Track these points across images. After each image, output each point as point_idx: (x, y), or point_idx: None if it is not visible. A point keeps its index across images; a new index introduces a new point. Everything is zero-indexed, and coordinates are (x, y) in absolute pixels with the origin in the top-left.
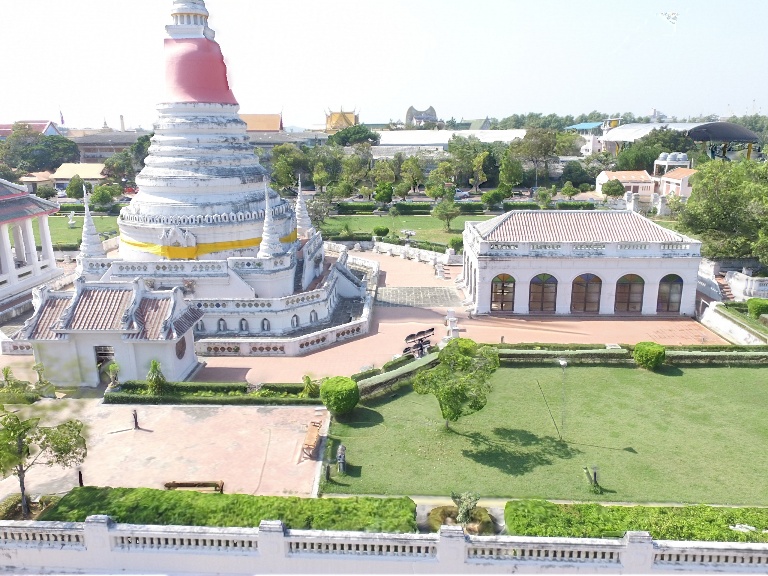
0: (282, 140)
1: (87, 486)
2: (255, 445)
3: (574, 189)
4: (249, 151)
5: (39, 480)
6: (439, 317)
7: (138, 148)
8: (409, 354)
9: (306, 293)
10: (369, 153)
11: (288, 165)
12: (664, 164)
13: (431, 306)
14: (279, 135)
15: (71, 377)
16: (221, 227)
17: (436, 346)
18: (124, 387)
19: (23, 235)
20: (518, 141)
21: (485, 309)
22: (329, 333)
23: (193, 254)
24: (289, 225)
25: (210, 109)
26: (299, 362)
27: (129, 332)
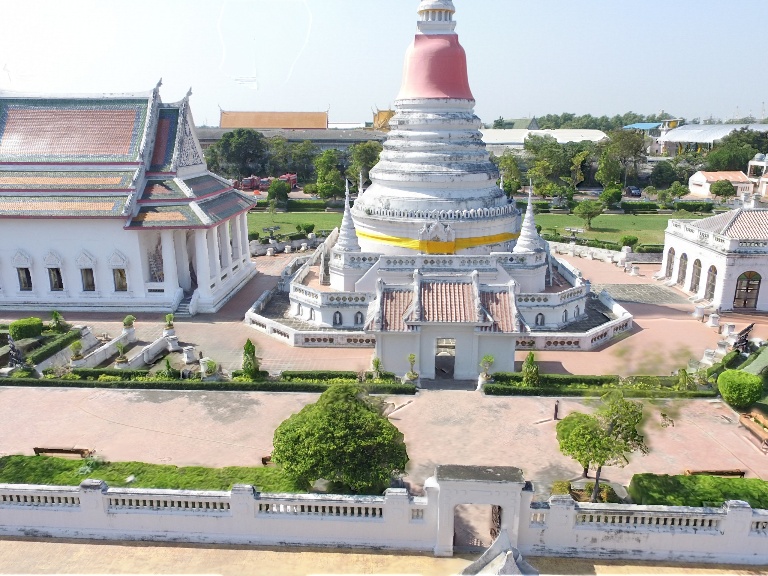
0: (363, 138)
1: (645, 473)
2: (697, 436)
3: (685, 189)
4: None
5: (531, 468)
6: (684, 313)
7: (225, 144)
8: (736, 349)
9: (574, 288)
10: None
11: None
12: (762, 165)
13: (662, 303)
14: (358, 133)
15: (408, 369)
16: (478, 222)
17: (751, 341)
18: (497, 379)
19: (232, 229)
20: (606, 141)
21: (728, 306)
22: (610, 328)
23: (452, 249)
24: (520, 221)
25: (459, 105)
26: (602, 356)
27: (483, 324)
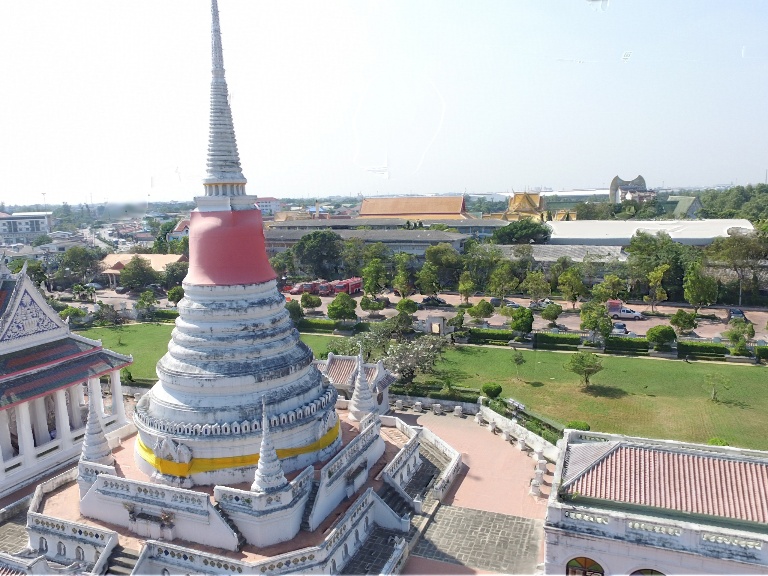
0: (439, 238)
1: None
2: None
3: None
4: (278, 336)
5: None
6: None
7: (299, 247)
8: None
9: (292, 555)
10: (530, 256)
11: (432, 273)
12: None
13: (488, 568)
14: (438, 232)
15: None
16: (219, 441)
17: None
18: None
19: None
20: (716, 246)
21: None
22: None
23: (185, 472)
24: (318, 429)
25: (230, 292)
26: None
27: None
